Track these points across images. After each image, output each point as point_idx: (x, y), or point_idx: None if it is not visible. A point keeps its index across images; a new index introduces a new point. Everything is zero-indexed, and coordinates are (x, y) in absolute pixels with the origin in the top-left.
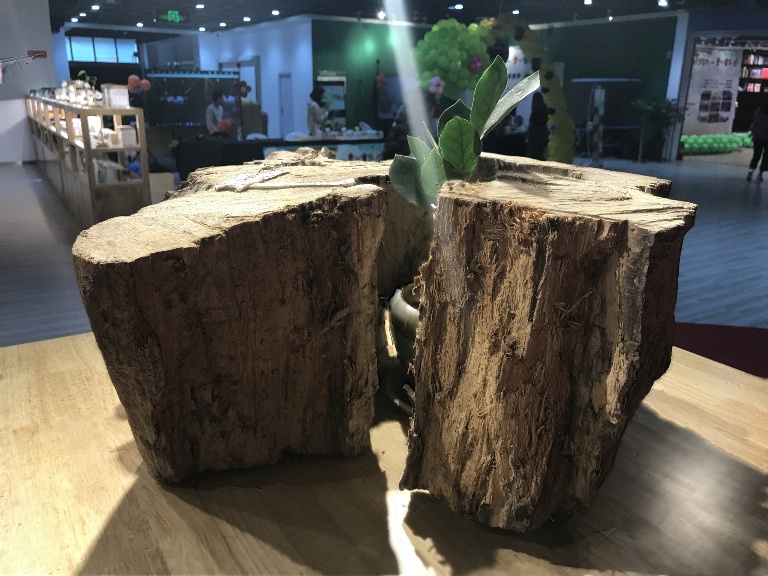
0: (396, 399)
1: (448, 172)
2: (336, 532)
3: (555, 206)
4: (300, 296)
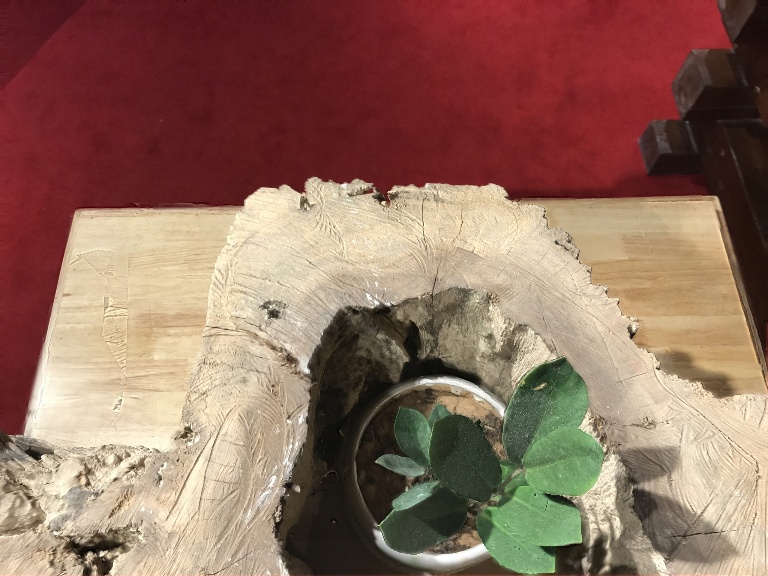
0: (425, 574)
1: None
2: None
3: None
4: None
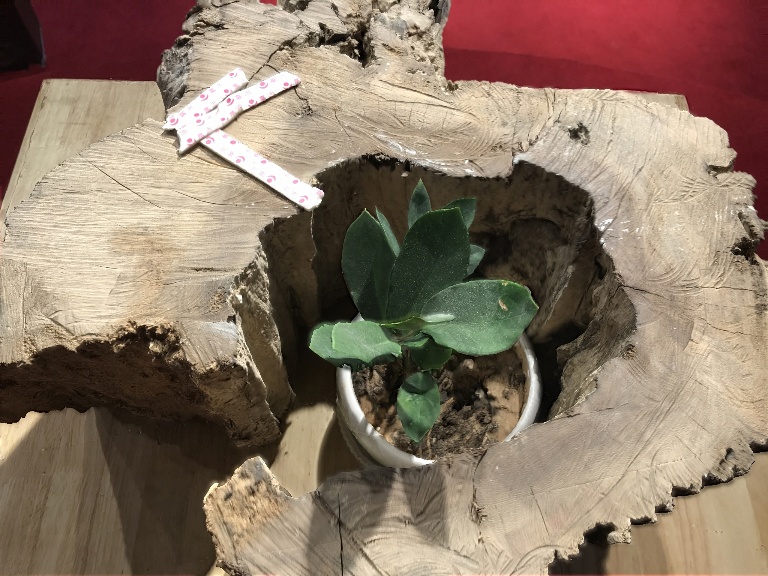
0: None
1: None
2: (176, 539)
3: None
4: (162, 377)
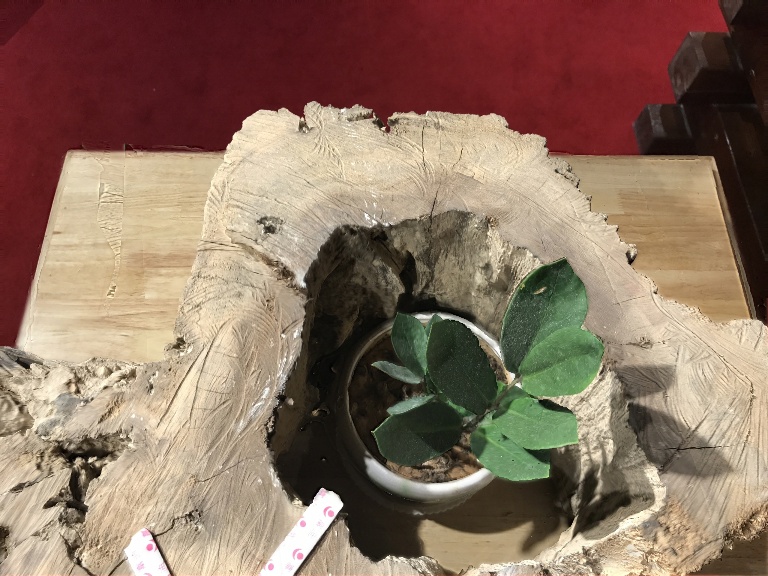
0: (414, 512)
1: (537, 455)
2: None
3: (763, 488)
4: None
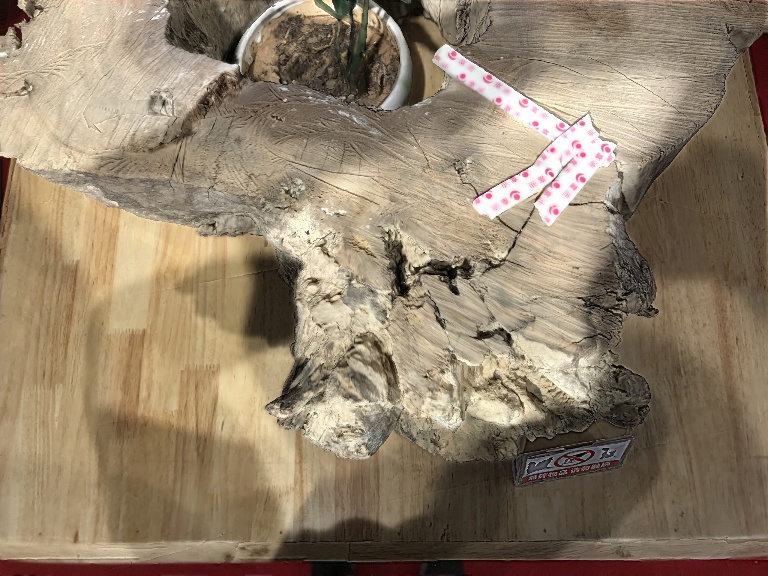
0: None
1: None
2: None
3: None
4: None
